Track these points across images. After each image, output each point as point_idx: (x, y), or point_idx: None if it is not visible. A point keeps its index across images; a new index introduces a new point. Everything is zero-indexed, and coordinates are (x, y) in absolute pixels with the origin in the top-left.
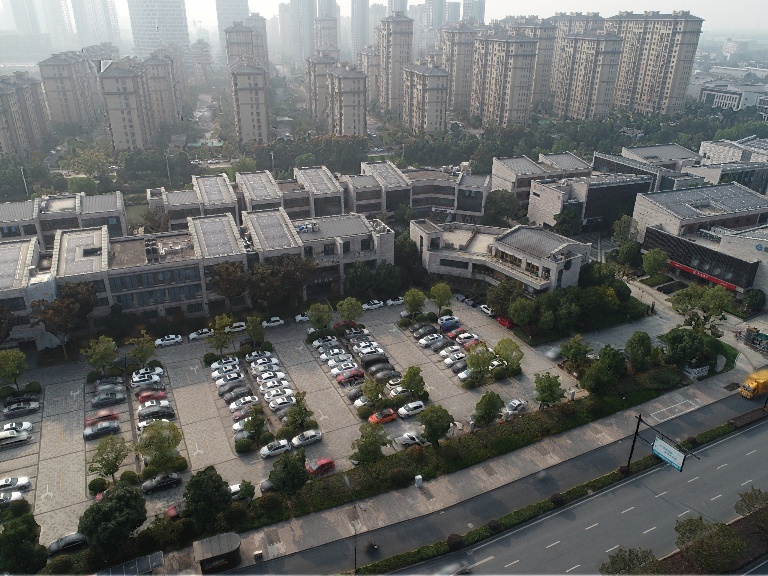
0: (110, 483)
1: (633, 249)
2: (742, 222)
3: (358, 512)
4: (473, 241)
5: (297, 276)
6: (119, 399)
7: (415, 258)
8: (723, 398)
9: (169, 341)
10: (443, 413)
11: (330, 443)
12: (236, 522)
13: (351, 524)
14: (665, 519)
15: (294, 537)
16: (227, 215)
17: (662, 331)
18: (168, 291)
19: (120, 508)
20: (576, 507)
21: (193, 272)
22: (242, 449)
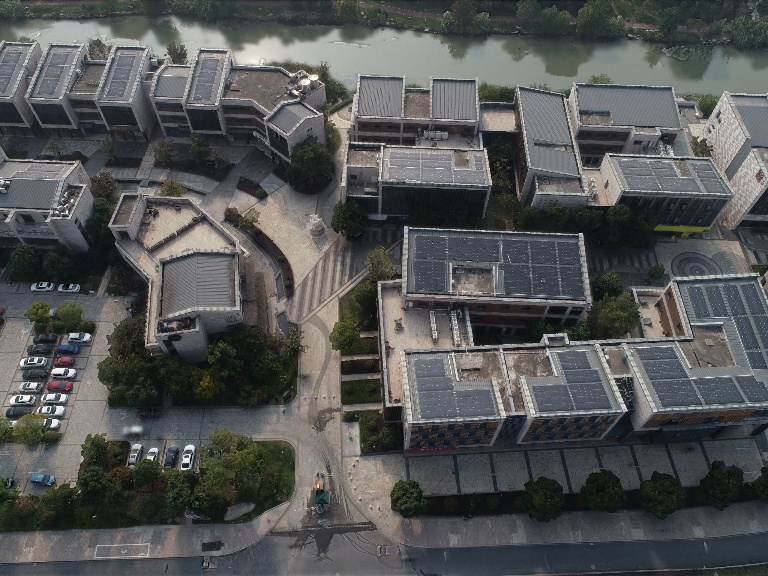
0: None
1: (363, 296)
2: (517, 309)
3: None
4: (177, 237)
5: None
6: None
7: None
8: (183, 557)
9: None
10: None
11: None
12: None
13: None
14: None
15: None
16: None
17: (256, 434)
18: None
19: None
20: None
21: None
22: None
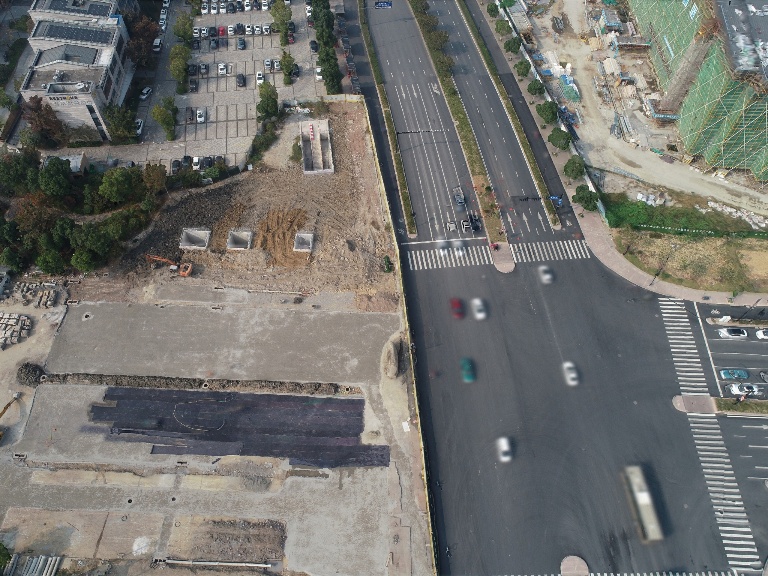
0: None
1: None
2: None
3: None
4: None
5: None
6: None
7: None
8: None
9: None
10: None
11: None
12: None
13: None
14: None
15: (337, 3)
16: None
17: None
18: (128, 2)
19: None
20: None
21: None
22: None
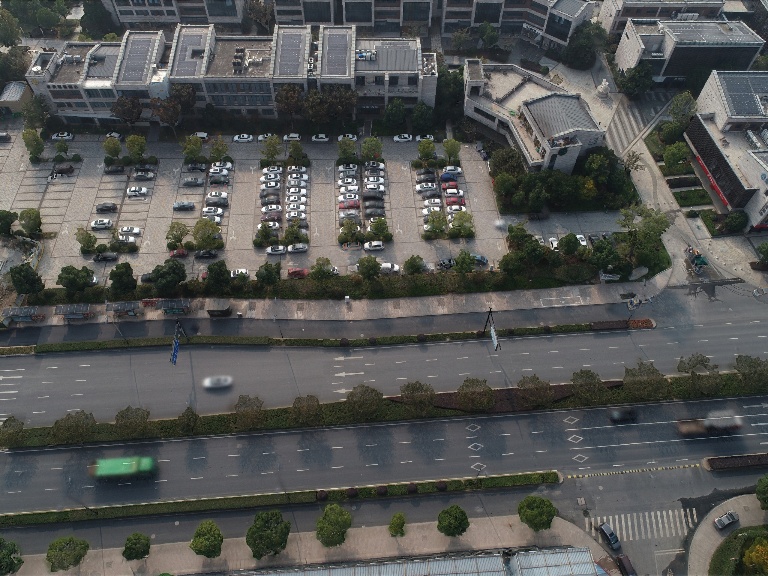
0: (179, 246)
1: (674, 131)
2: None
3: (304, 306)
4: (515, 92)
5: (339, 109)
6: (199, 184)
7: (459, 97)
8: (610, 303)
9: (243, 139)
10: (372, 264)
11: (311, 255)
12: (236, 292)
13: (297, 312)
14: (480, 371)
15: (263, 310)
16: (307, 28)
17: (624, 228)
18: (248, 97)
19: (169, 273)
20: (432, 346)
21: (265, 87)
22: (256, 245)
